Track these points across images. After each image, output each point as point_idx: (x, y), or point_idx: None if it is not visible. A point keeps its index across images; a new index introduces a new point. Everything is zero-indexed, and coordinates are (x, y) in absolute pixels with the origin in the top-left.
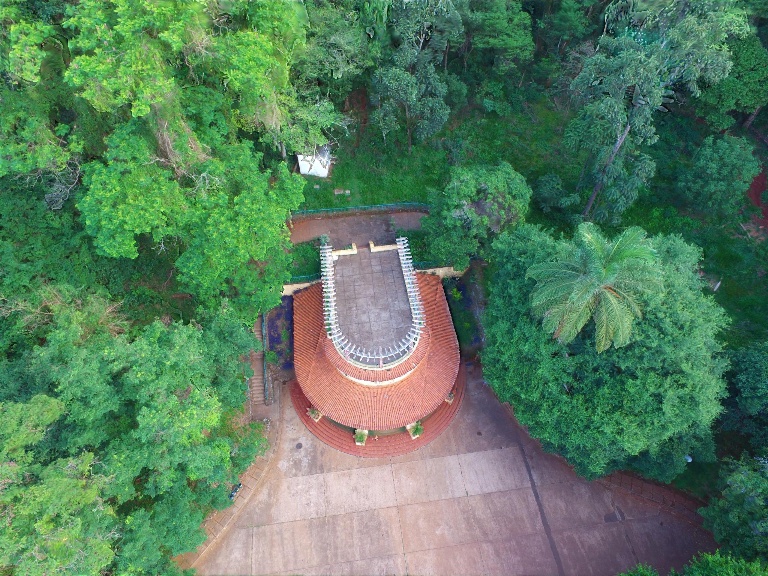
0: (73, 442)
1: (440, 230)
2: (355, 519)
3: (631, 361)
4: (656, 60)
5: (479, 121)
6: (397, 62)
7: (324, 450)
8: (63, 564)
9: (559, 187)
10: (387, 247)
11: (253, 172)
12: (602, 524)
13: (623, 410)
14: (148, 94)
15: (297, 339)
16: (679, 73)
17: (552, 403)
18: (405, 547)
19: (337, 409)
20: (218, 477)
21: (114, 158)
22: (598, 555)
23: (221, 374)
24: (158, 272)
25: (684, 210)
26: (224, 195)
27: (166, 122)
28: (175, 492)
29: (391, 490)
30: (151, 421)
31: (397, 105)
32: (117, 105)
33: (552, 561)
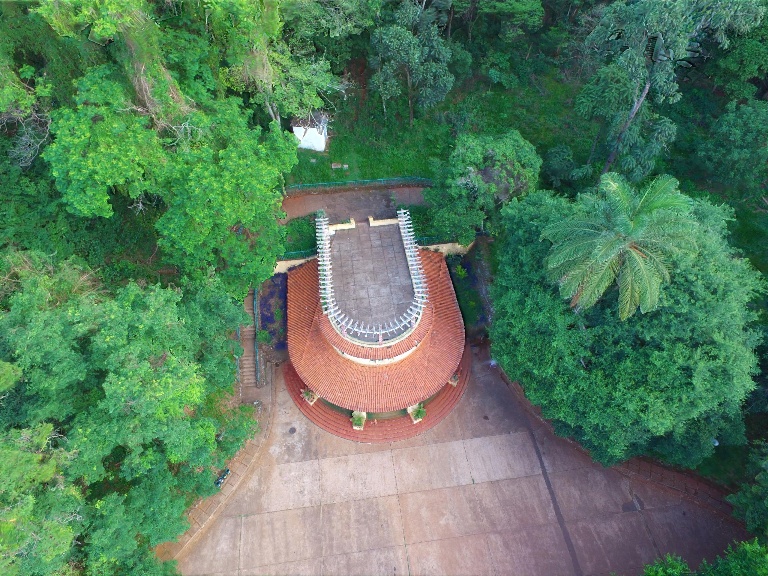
0: (33, 414)
1: (444, 202)
2: (352, 508)
3: (657, 331)
4: (682, 3)
5: (484, 93)
6: (398, 20)
7: (319, 435)
8: (11, 549)
9: (570, 158)
10: (387, 221)
11: (241, 128)
12: (620, 514)
13: (647, 385)
14: (114, 11)
15: (291, 317)
16: (705, 22)
17: (568, 379)
18: (406, 538)
19: (333, 390)
20: (202, 460)
21: (84, 102)
22: (616, 547)
23: (208, 351)
24: (143, 246)
25: (702, 184)
26: (208, 148)
27: (143, 65)
28: (154, 476)
29: (391, 477)
30: (119, 389)
31: (398, 70)
32: (80, 27)
33: (566, 553)
